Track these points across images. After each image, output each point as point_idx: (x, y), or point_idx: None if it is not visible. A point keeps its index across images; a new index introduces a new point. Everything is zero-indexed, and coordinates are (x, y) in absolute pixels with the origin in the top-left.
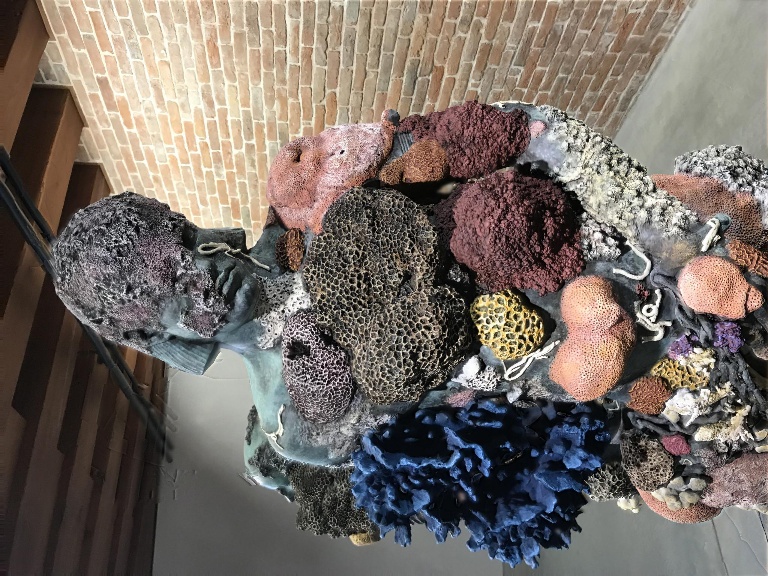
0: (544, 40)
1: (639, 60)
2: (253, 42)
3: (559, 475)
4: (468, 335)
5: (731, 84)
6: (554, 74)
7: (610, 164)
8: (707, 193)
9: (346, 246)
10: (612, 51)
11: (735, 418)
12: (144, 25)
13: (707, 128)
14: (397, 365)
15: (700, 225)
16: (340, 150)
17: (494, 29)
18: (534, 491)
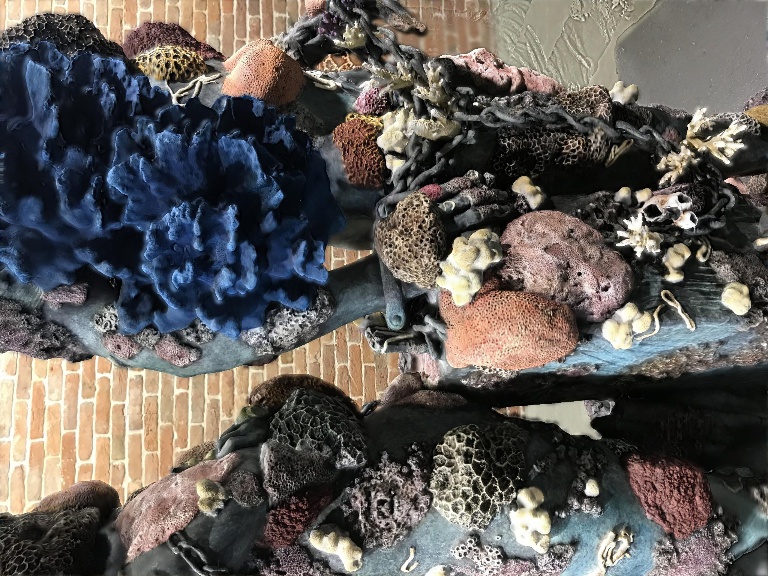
0: None
1: None
2: None
3: None
4: None
5: None
6: None
7: None
8: None
9: None
10: None
11: None
12: None
13: None
14: None
15: None
16: None
17: None
18: None
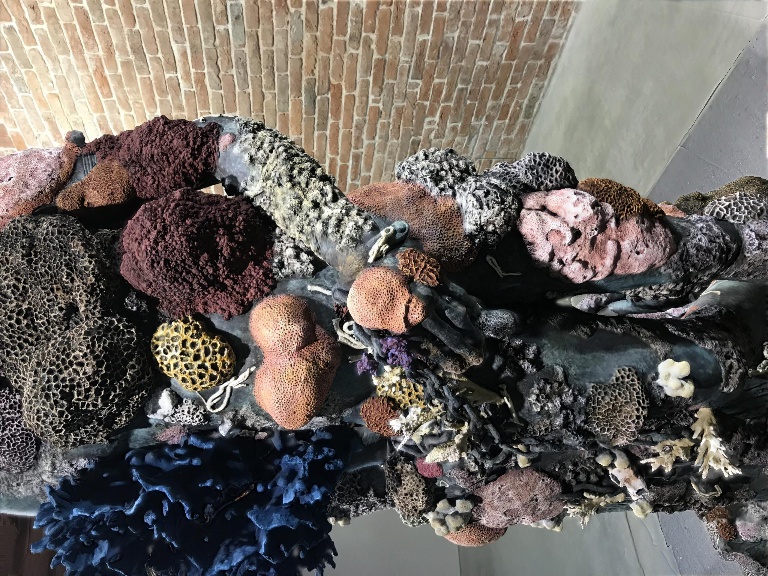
0: (437, 52)
1: (535, 67)
2: (141, 70)
3: (276, 511)
4: (145, 368)
5: (614, 86)
6: (453, 86)
7: (292, 175)
8: (408, 199)
9: (3, 280)
10: (507, 60)
11: (458, 436)
12: (26, 58)
13: (598, 131)
14: (50, 407)
15: (373, 234)
16: (8, 177)
17: (385, 44)
18: (259, 529)
